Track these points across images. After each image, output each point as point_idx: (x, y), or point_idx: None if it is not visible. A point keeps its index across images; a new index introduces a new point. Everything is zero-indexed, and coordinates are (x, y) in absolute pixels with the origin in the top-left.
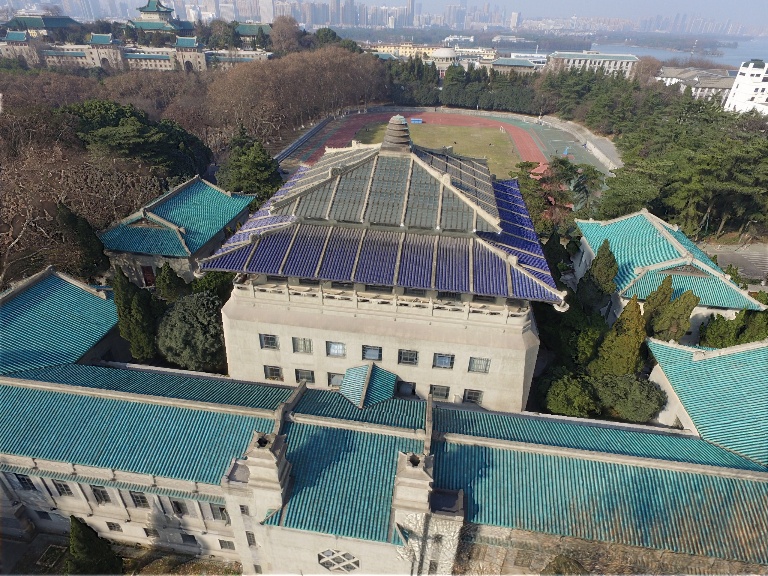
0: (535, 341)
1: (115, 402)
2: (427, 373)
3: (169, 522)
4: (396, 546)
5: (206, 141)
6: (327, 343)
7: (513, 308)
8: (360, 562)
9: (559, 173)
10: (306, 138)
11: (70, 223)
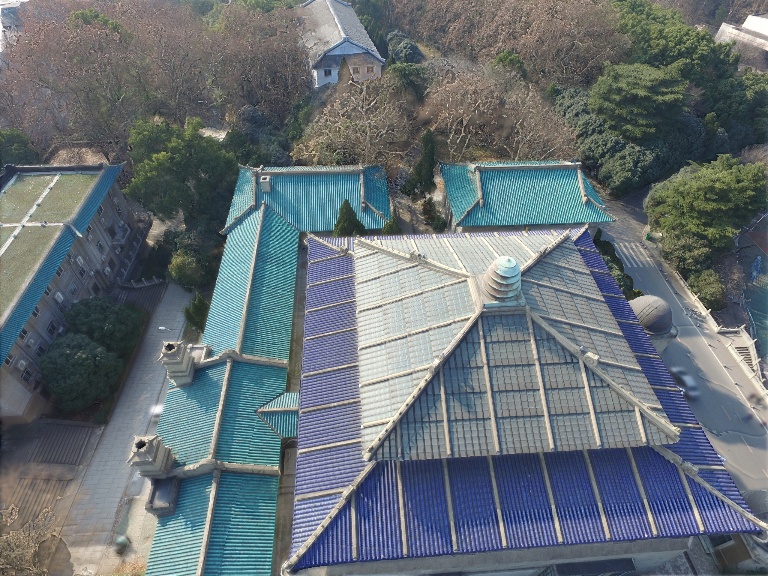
0: (321, 569)
1: None
2: None
3: None
4: None
5: None
6: None
7: None
8: None
9: None
10: None
11: (426, 146)
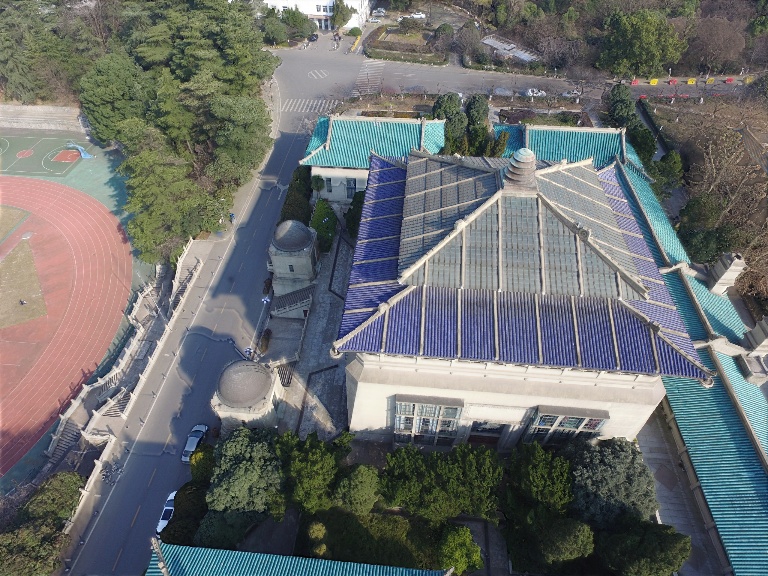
0: None
1: None
2: None
3: None
4: None
5: None
6: None
7: None
8: None
9: None
10: None
11: None
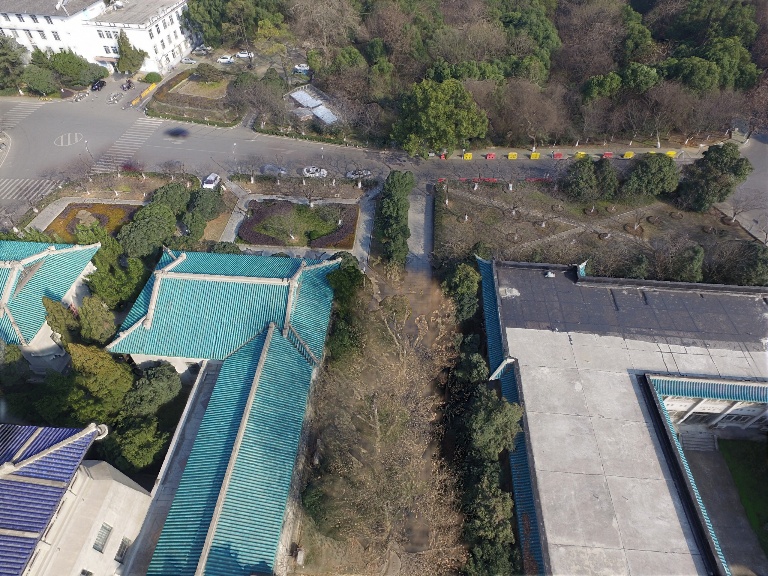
0: (103, 466)
1: None
2: None
3: None
4: None
5: None
6: None
7: None
8: None
9: None
10: None
11: None
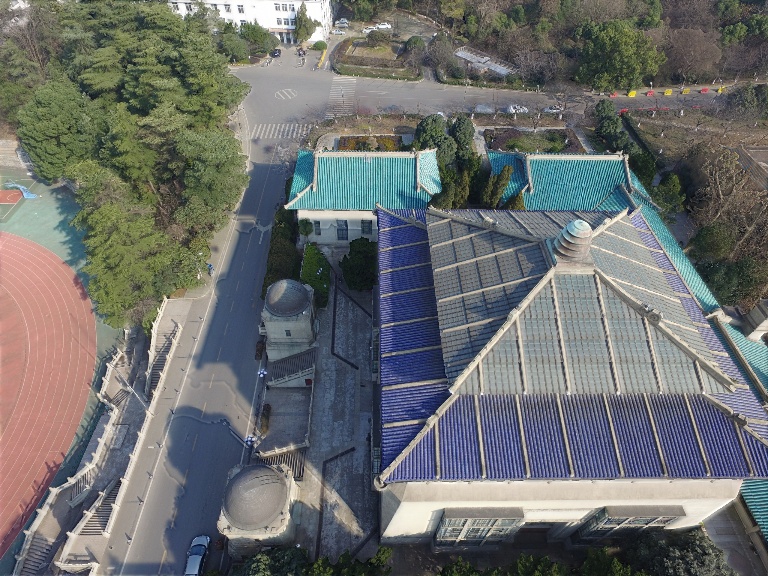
0: None
1: None
2: None
3: None
4: None
5: None
6: None
7: None
8: None
9: None
10: None
11: None
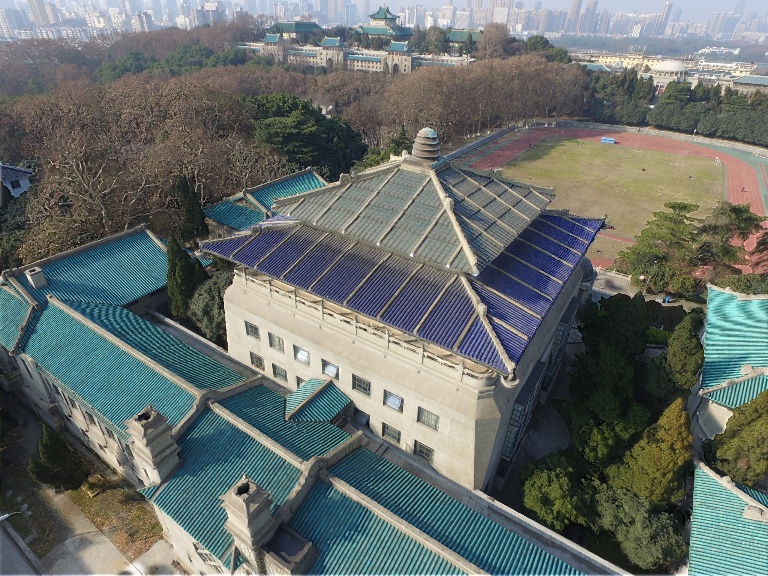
0: (494, 413)
1: (112, 345)
2: (379, 408)
3: (127, 460)
4: (240, 569)
5: (377, 138)
6: (295, 347)
7: (482, 366)
8: (222, 569)
9: (727, 223)
10: (475, 146)
11: (184, 192)
